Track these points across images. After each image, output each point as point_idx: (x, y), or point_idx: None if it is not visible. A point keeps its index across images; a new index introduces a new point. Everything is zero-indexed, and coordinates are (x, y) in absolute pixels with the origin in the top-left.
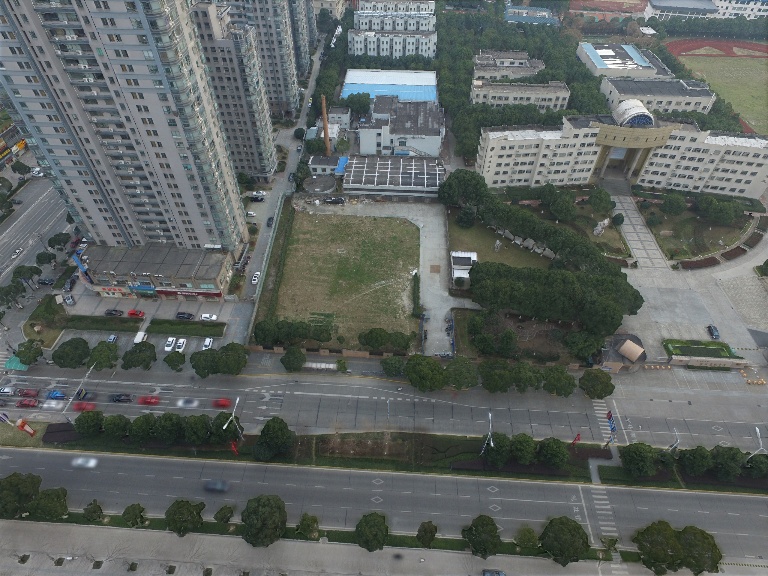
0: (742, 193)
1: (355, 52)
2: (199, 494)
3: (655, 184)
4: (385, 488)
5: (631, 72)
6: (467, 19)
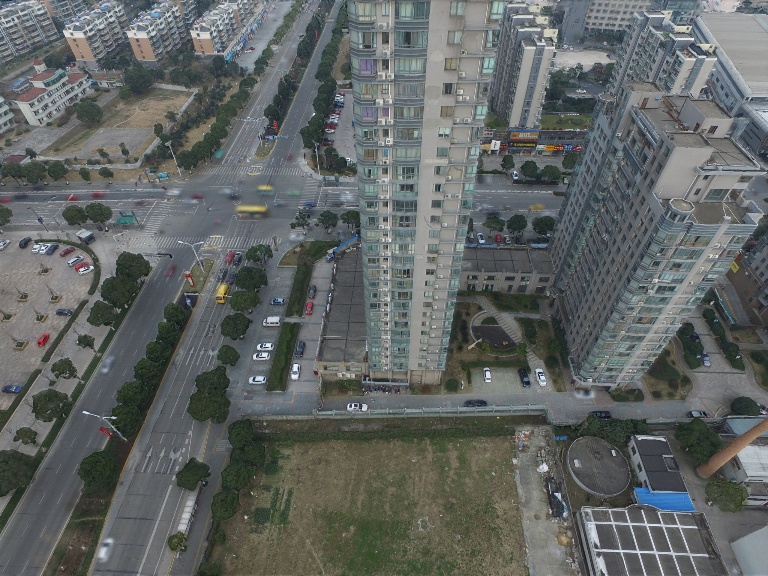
0: None
1: None
2: None
3: None
4: None
5: None
6: None
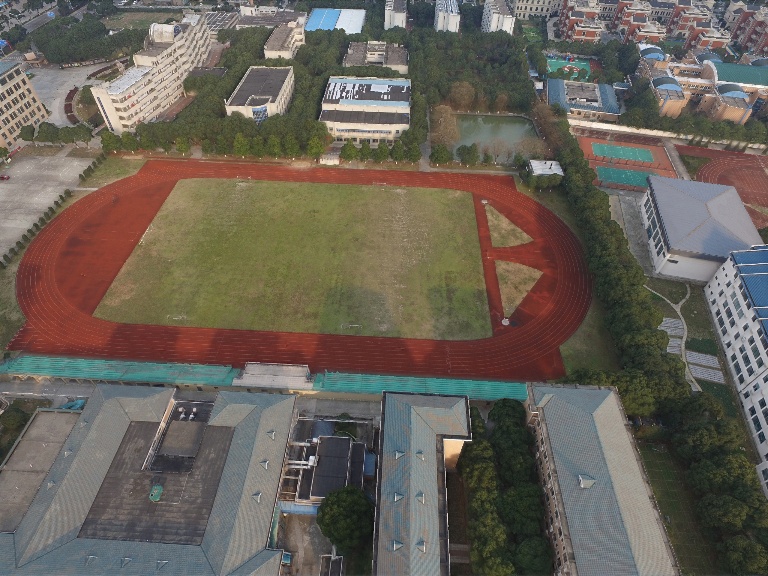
0: None
1: None
2: None
3: None
4: (35, 26)
5: None
6: None
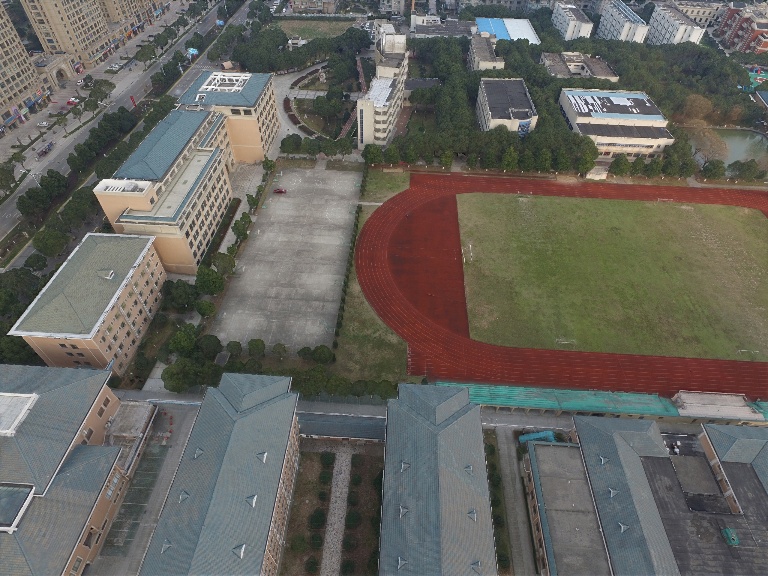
0: None
1: None
2: (214, 15)
3: None
4: None
5: None
6: None
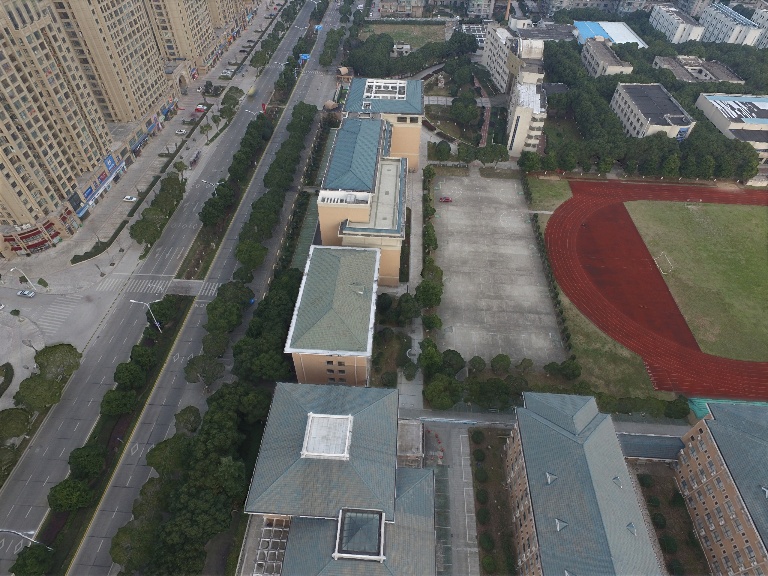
0: None
1: None
2: None
3: None
4: (297, 39)
5: (716, 113)
6: None
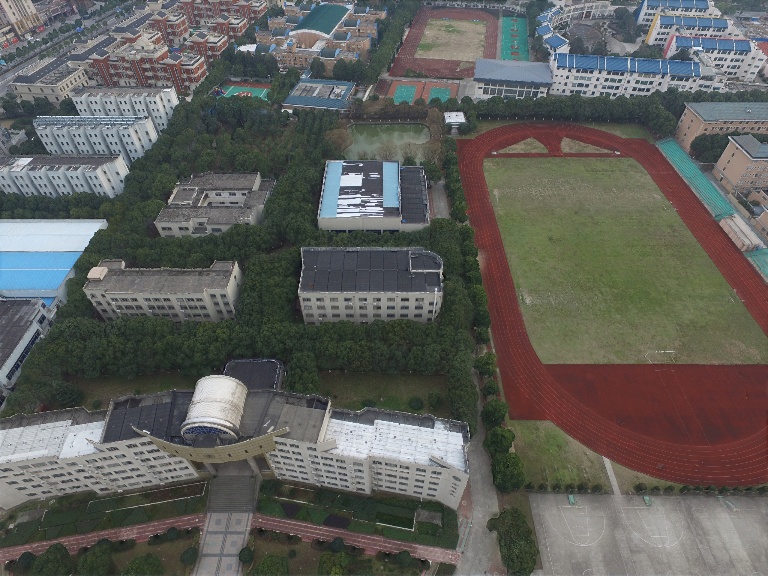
0: (433, 497)
1: (3, 189)
2: None
3: (302, 479)
4: None
5: (367, 221)
6: (223, 108)
